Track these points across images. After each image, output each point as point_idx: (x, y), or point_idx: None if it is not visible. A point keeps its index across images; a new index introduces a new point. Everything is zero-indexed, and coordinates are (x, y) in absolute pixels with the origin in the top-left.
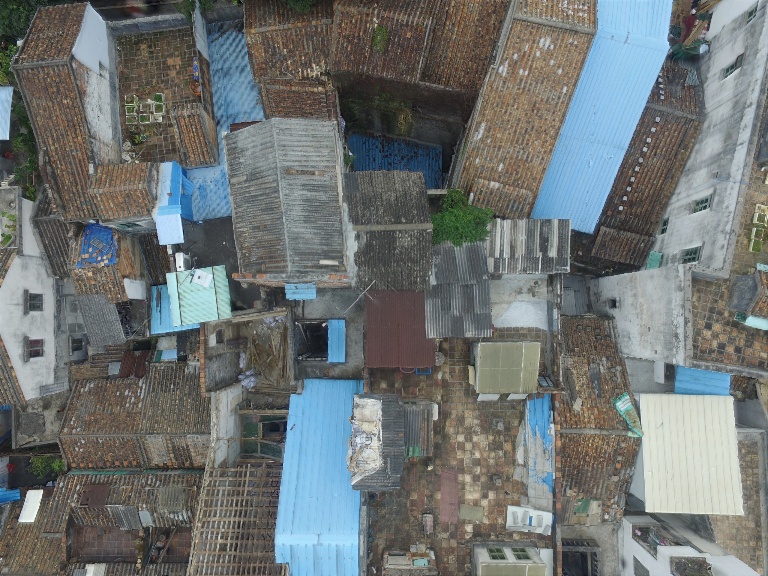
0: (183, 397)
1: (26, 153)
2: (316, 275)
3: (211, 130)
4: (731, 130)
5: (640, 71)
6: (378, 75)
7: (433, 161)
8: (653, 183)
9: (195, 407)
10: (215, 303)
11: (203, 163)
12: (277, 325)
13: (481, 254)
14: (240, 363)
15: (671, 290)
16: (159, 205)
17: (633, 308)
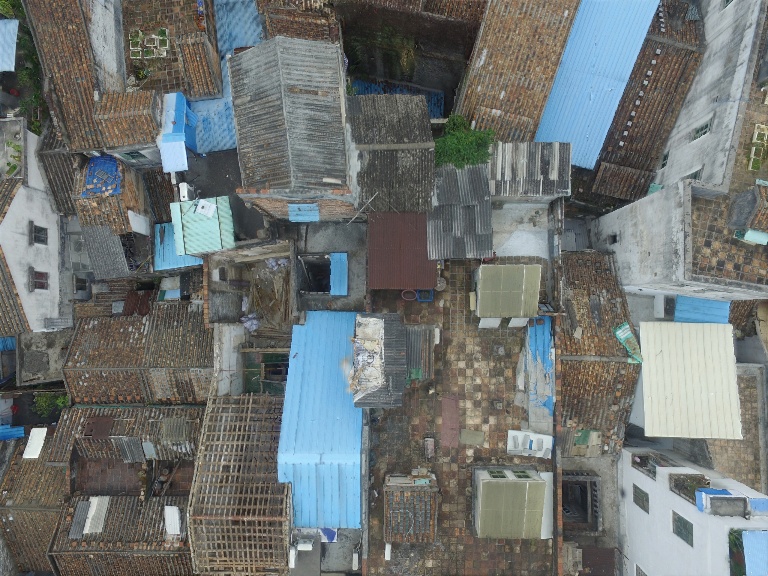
0: (186, 333)
1: (31, 91)
2: (319, 190)
3: (215, 62)
4: (731, 54)
5: None
6: (381, 5)
7: (435, 107)
8: (653, 117)
9: (198, 342)
10: (218, 233)
11: (207, 94)
12: (279, 270)
13: (483, 176)
14: (243, 306)
15: (671, 209)
16: (163, 132)
17: (633, 237)
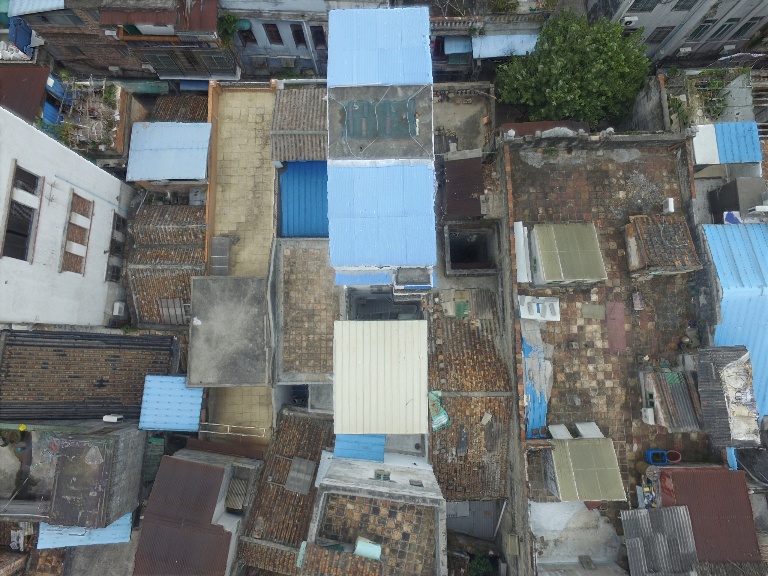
0: None
1: None
2: None
3: None
4: None
5: None
6: None
7: None
8: None
9: None
10: None
11: None
12: None
13: None
14: None
15: None
16: None
17: None
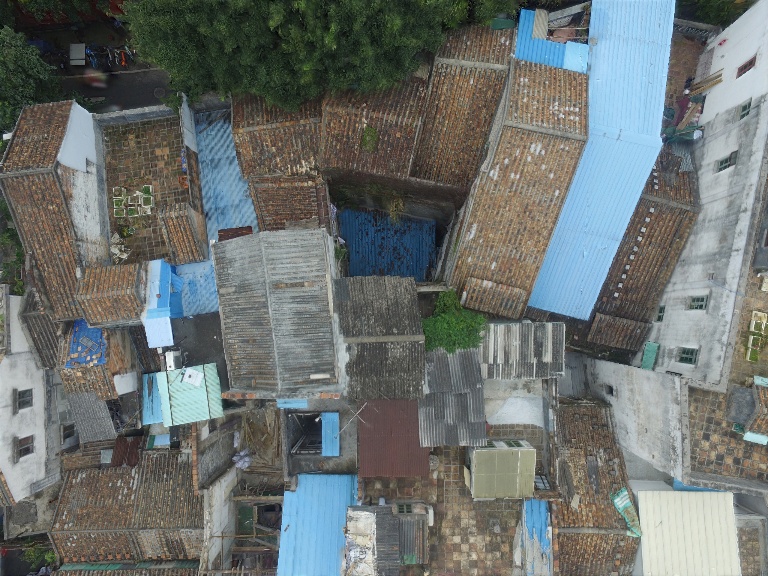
0: (176, 488)
1: None
2: (307, 394)
3: (200, 226)
4: (726, 231)
5: (633, 166)
6: (368, 172)
7: (426, 235)
8: (648, 270)
9: (188, 499)
10: (206, 402)
11: (192, 261)
12: None
13: (474, 361)
14: (234, 443)
15: (668, 400)
16: (148, 308)
17: (630, 403)
